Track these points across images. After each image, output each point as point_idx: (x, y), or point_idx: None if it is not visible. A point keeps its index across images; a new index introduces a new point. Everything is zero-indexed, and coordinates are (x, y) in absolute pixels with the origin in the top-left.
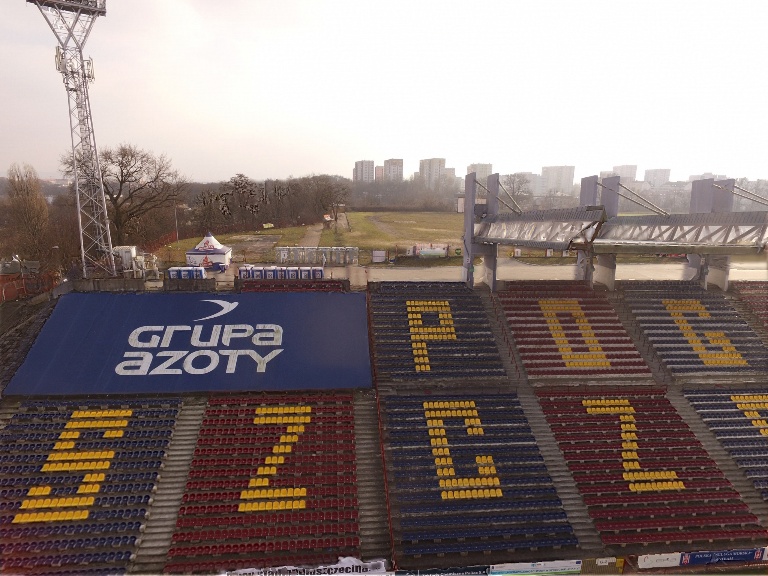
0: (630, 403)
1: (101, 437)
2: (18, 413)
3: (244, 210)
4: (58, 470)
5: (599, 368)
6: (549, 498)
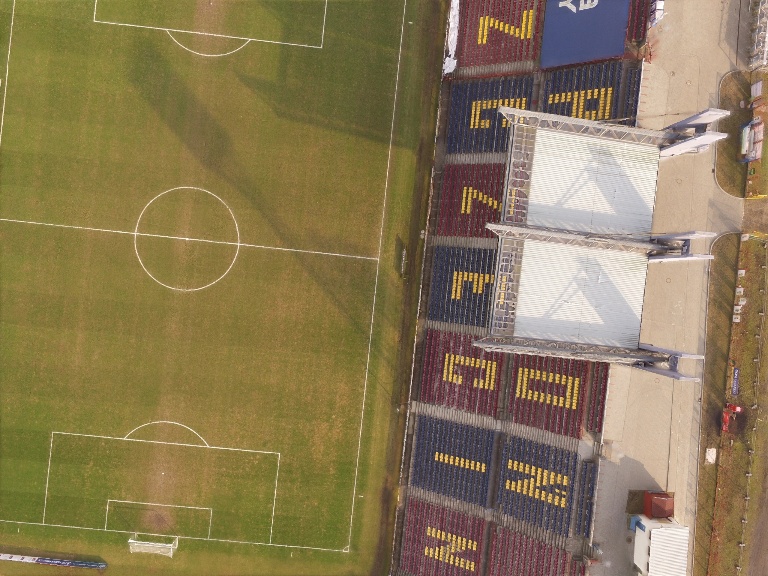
0: None
1: None
2: None
3: None
4: None
5: None
6: (467, 149)
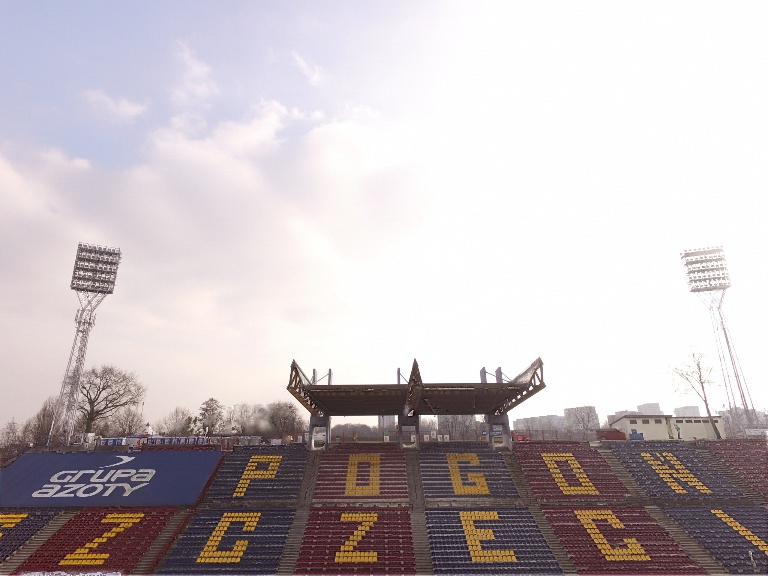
0: (378, 516)
1: None
2: None
3: (213, 429)
4: None
5: (369, 495)
6: None
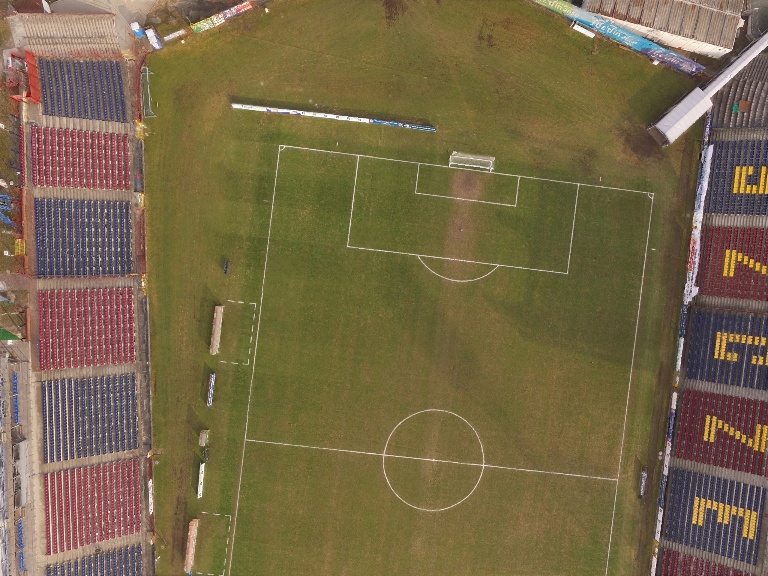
0: (762, 452)
1: None
2: None
3: None
4: (762, 173)
5: None
6: (710, 377)
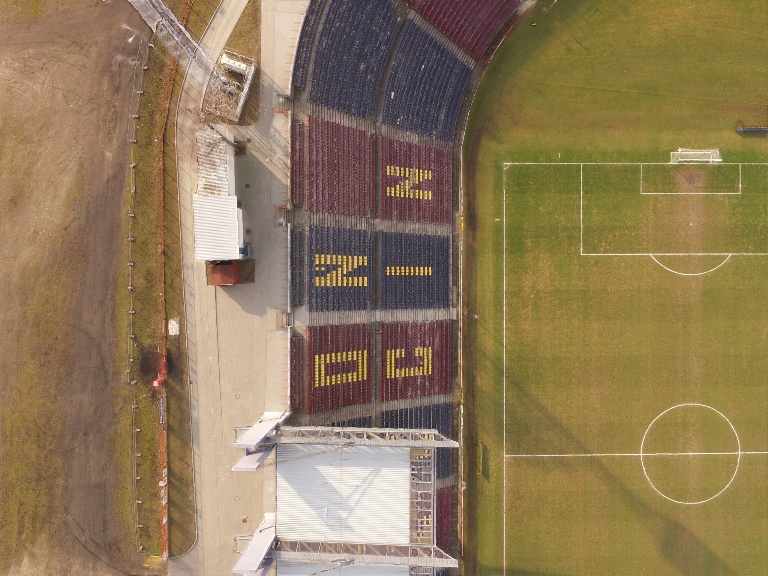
0: None
1: None
2: None
3: None
4: None
5: None
6: None
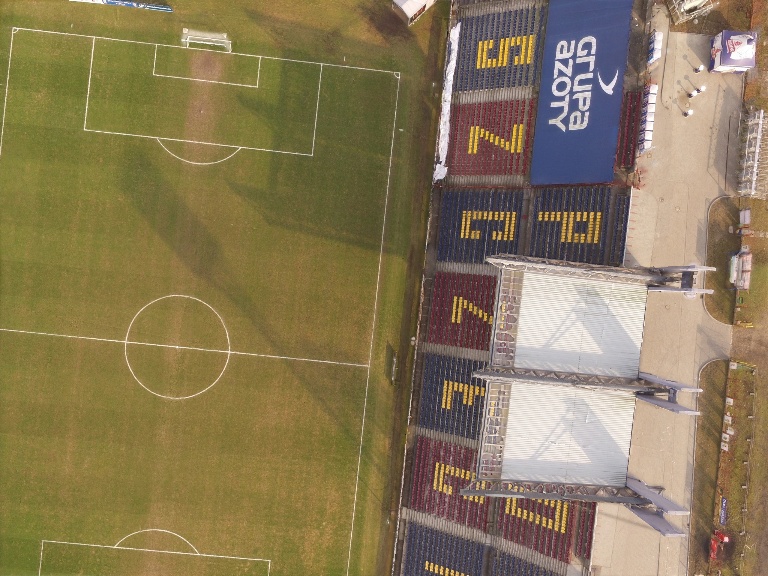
0: None
1: (516, 56)
2: (539, 8)
3: None
4: (500, 46)
5: None
6: (457, 258)
